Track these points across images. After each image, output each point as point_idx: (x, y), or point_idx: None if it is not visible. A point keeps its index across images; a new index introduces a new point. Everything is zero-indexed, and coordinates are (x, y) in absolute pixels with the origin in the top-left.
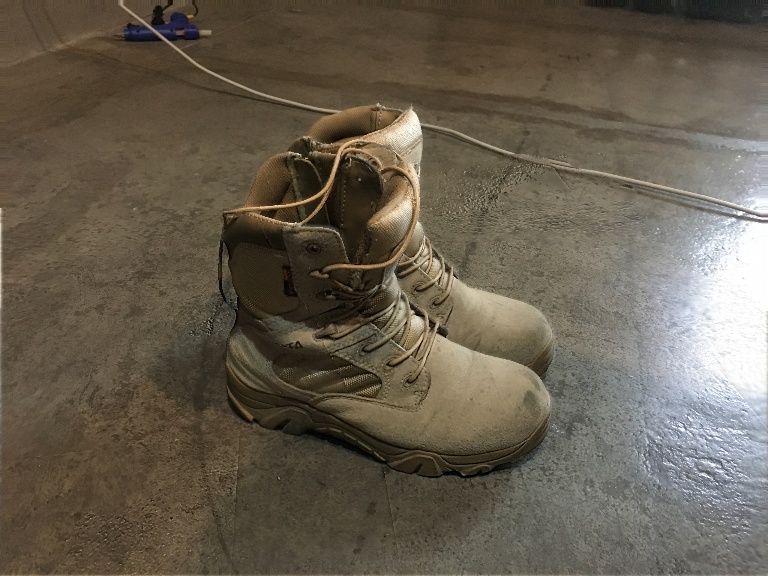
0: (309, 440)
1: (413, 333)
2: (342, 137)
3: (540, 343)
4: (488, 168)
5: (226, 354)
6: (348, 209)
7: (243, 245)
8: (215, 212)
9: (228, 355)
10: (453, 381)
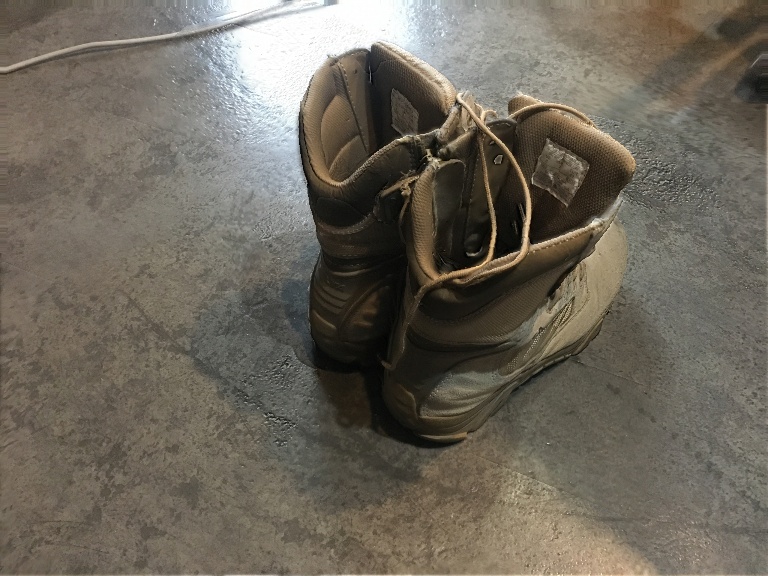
0: (513, 400)
1: None
2: None
3: None
4: (184, 63)
5: (414, 411)
6: (478, 180)
7: (520, 287)
8: (31, 328)
9: (424, 409)
10: None
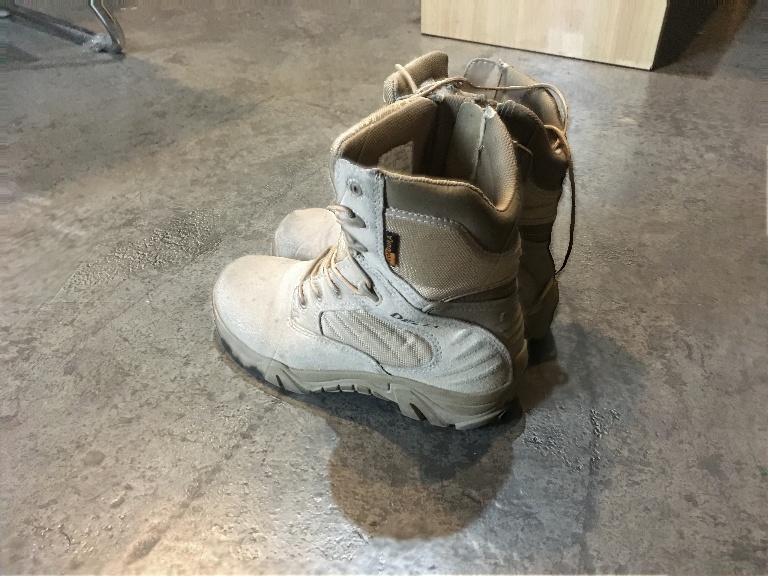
0: None
1: None
2: None
3: None
4: None
5: None
6: None
7: None
8: None
9: None
10: None
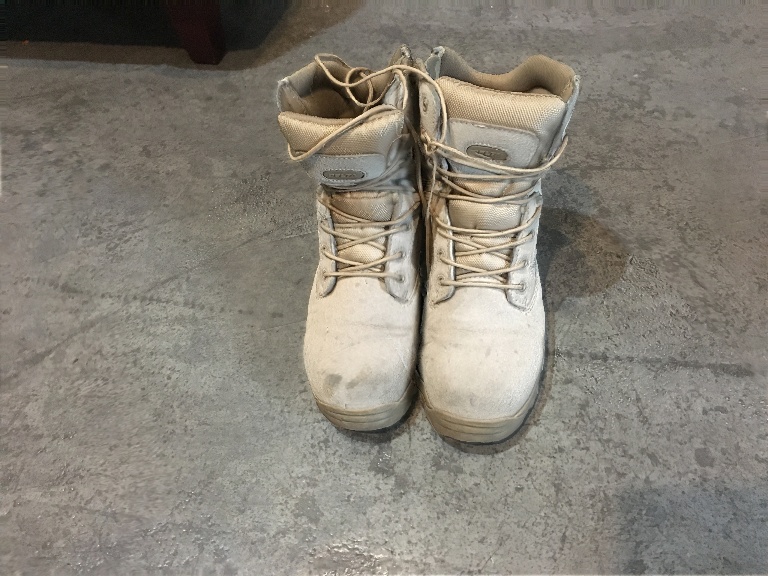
0: None
1: (350, 251)
2: (546, 87)
3: (445, 403)
4: None
5: None
6: None
7: None
8: (666, 125)
9: None
10: (339, 311)
